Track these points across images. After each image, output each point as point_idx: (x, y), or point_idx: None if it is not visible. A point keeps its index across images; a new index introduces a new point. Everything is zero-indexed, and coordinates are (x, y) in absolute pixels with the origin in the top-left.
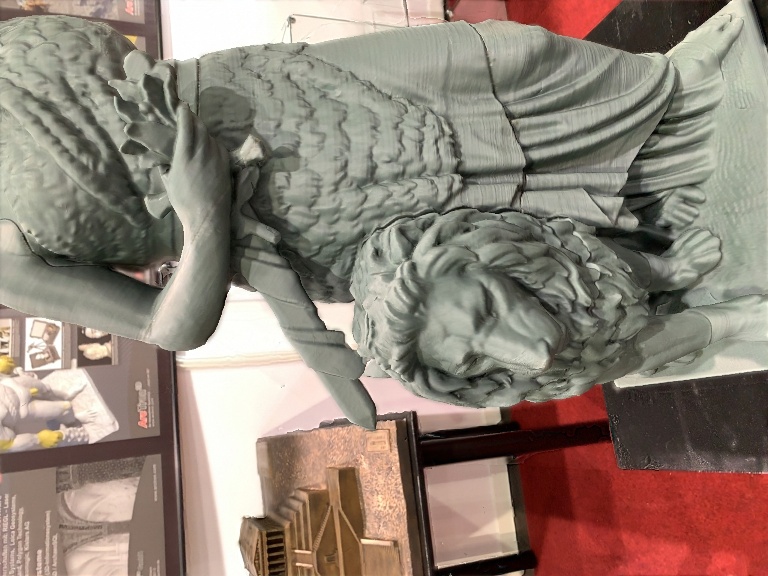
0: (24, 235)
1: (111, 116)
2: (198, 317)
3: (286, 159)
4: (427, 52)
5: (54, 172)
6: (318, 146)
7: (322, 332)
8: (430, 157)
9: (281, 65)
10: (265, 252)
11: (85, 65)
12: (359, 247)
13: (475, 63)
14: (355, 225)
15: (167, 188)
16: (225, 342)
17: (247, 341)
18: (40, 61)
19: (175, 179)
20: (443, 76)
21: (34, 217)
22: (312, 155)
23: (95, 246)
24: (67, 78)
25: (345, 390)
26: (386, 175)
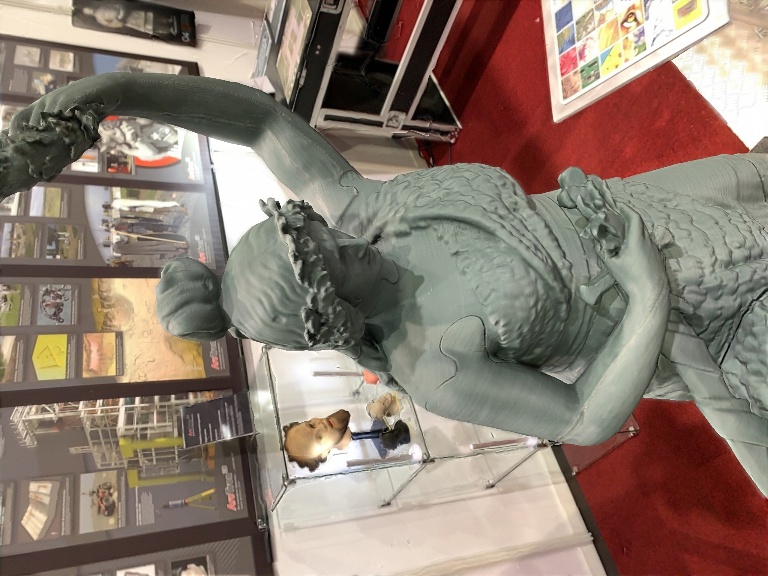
0: (485, 329)
1: (538, 225)
2: (638, 393)
3: (671, 249)
4: (720, 172)
5: (521, 266)
6: (689, 238)
7: (737, 399)
8: (763, 243)
9: (624, 188)
10: (682, 325)
11: (511, 189)
12: (736, 321)
13: (754, 178)
14: (735, 299)
15: (614, 269)
16: (327, 572)
17: (350, 568)
18: (483, 187)
19: (632, 256)
20: (736, 188)
21: (507, 306)
22: (688, 245)
23: (532, 339)
24: (502, 198)
25: (763, 460)
26: (740, 258)
